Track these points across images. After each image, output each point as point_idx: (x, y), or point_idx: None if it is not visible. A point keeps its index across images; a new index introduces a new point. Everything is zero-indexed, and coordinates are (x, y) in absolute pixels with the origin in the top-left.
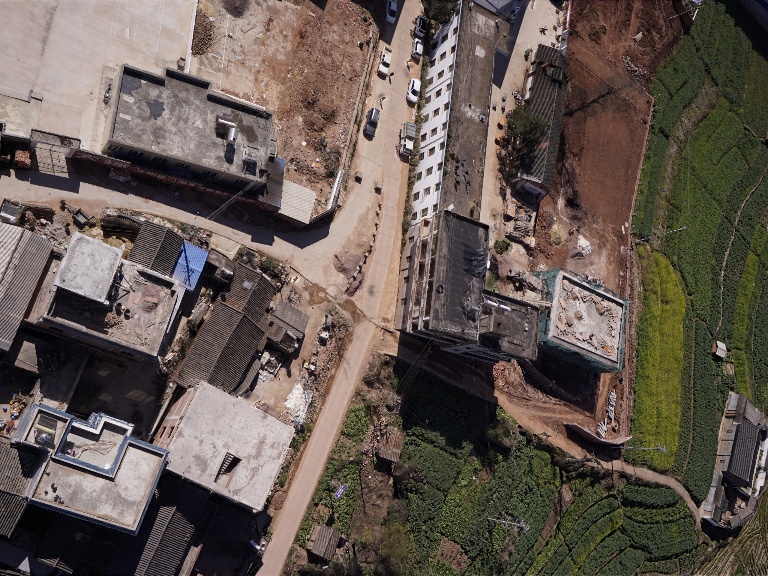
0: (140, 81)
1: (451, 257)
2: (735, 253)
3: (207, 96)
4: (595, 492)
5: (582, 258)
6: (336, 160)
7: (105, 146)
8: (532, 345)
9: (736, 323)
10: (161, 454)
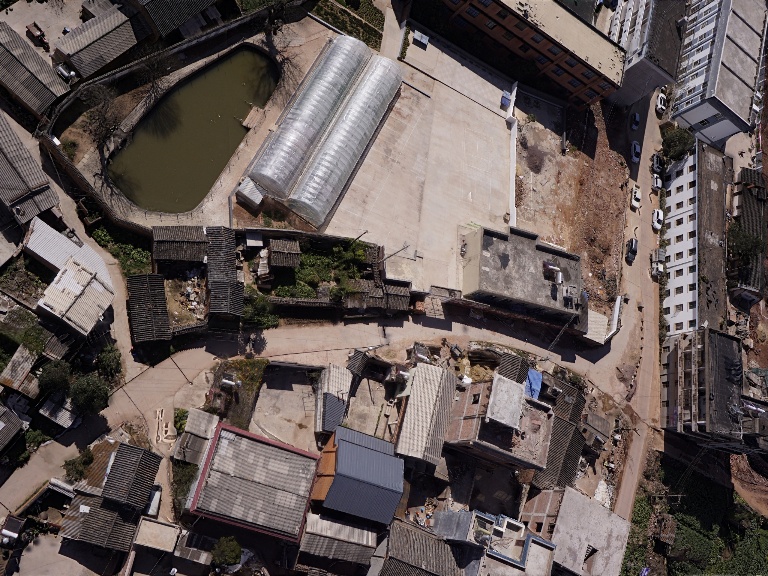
0: (492, 239)
1: (719, 369)
2: None
3: (536, 246)
4: None
5: None
6: (615, 287)
7: (470, 293)
8: None
9: None
10: (552, 548)
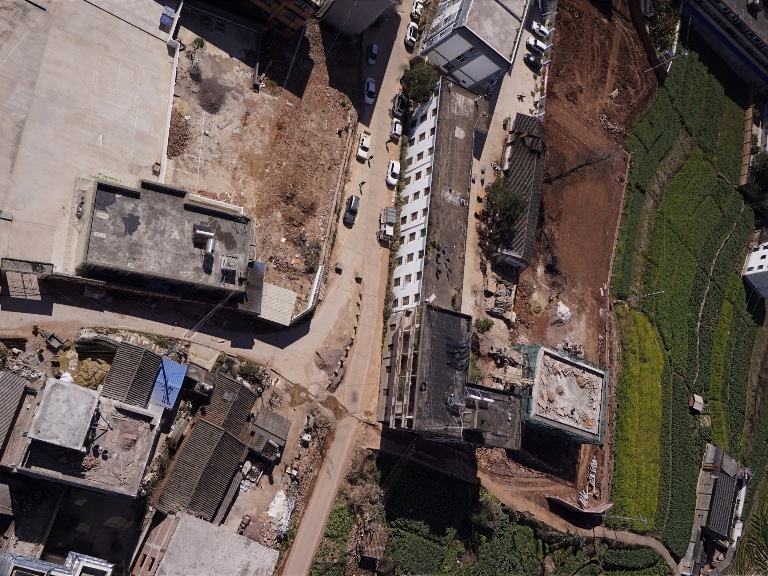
0: (114, 195)
1: (434, 353)
2: (710, 303)
3: (184, 205)
4: (577, 560)
5: (562, 325)
6: (316, 255)
7: (79, 265)
8: (515, 434)
9: (712, 373)
10: None
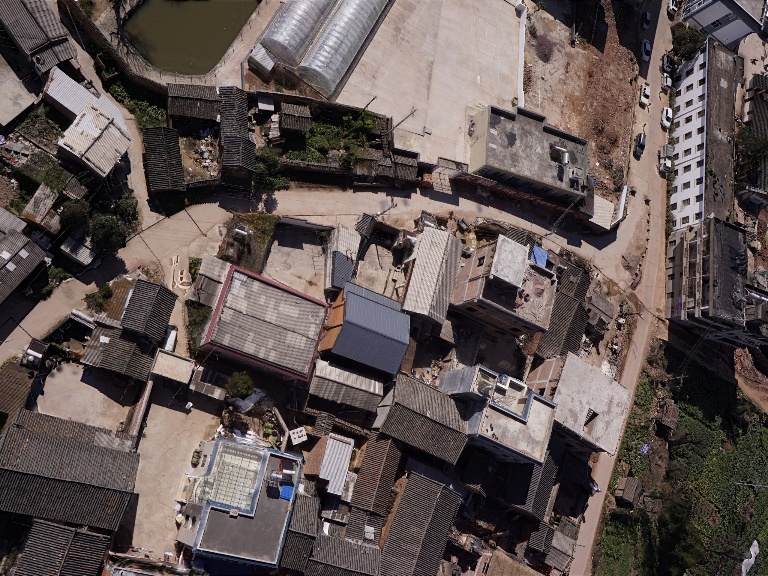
0: (500, 117)
1: (723, 256)
2: None
3: (543, 128)
4: None
5: None
6: (622, 177)
7: (477, 169)
8: None
9: None
10: (553, 406)
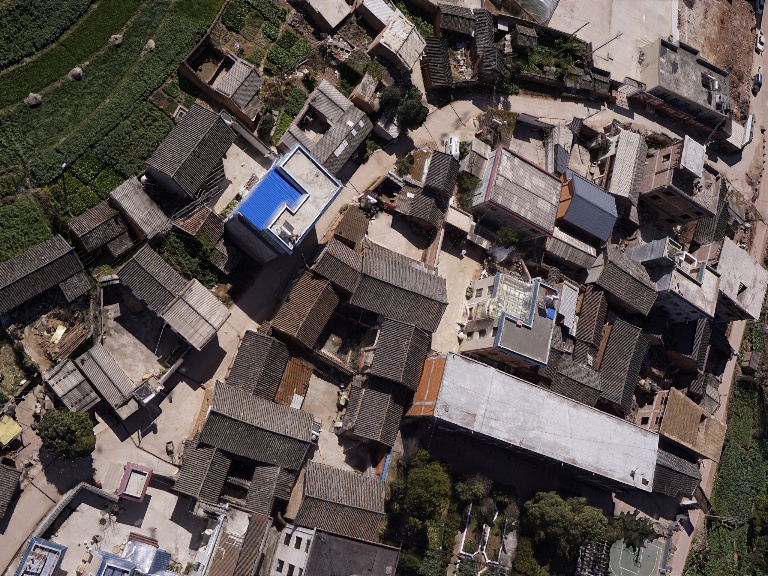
0: (666, 49)
1: None
2: None
3: (696, 60)
4: None
5: None
6: None
7: (649, 90)
8: None
9: None
10: (719, 275)
